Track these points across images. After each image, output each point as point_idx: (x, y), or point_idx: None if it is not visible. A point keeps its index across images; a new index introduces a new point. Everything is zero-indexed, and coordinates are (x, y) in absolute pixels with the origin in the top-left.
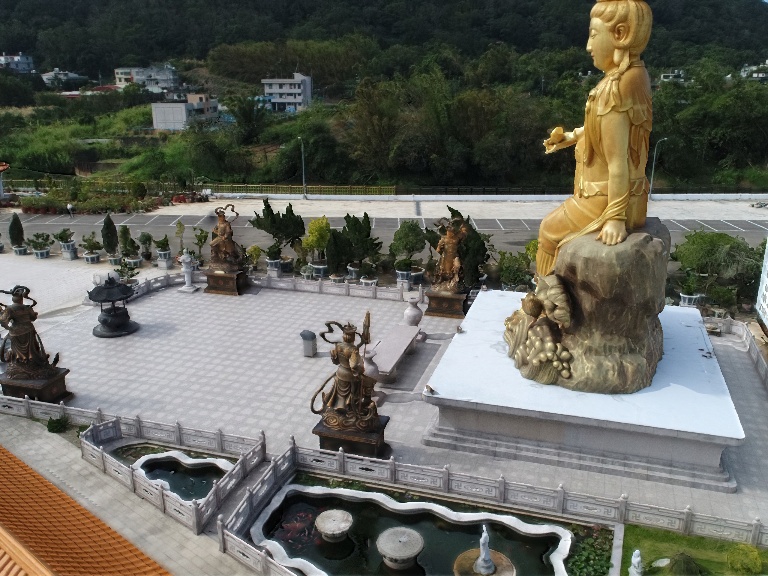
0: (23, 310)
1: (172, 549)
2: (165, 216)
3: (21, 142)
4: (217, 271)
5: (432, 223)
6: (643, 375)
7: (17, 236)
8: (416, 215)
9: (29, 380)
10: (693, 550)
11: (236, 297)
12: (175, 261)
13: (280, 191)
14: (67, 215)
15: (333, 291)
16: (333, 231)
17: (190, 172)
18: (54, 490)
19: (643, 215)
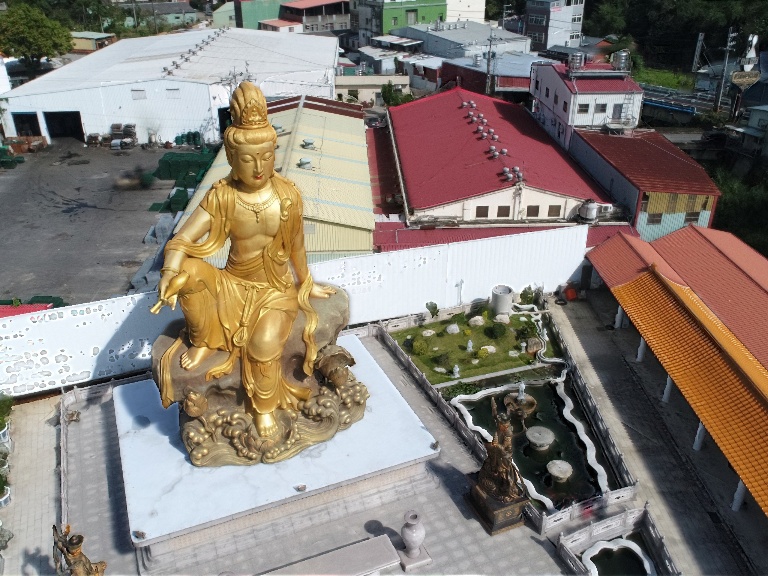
0: None
1: (666, 519)
2: None
3: None
4: None
5: None
6: None
7: None
8: None
9: None
10: (419, 367)
11: None
12: None
13: None
14: None
15: None
16: None
17: None
18: (754, 490)
19: None
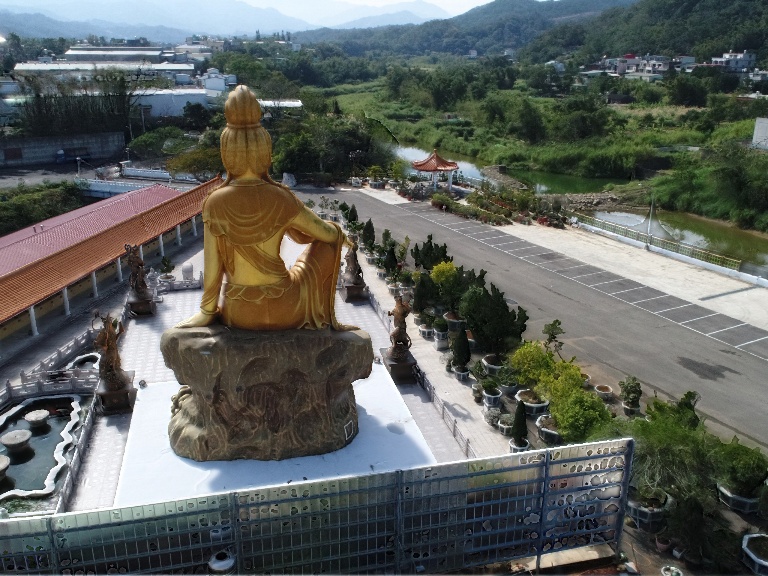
0: (134, 258)
1: None
2: (497, 232)
3: (601, 143)
4: (342, 279)
5: (683, 311)
6: (192, 448)
7: (353, 220)
8: (697, 298)
9: (132, 297)
10: None
11: (342, 303)
12: (397, 267)
13: (629, 235)
14: (448, 213)
15: (386, 324)
16: (426, 276)
17: (564, 198)
18: None
19: (245, 319)
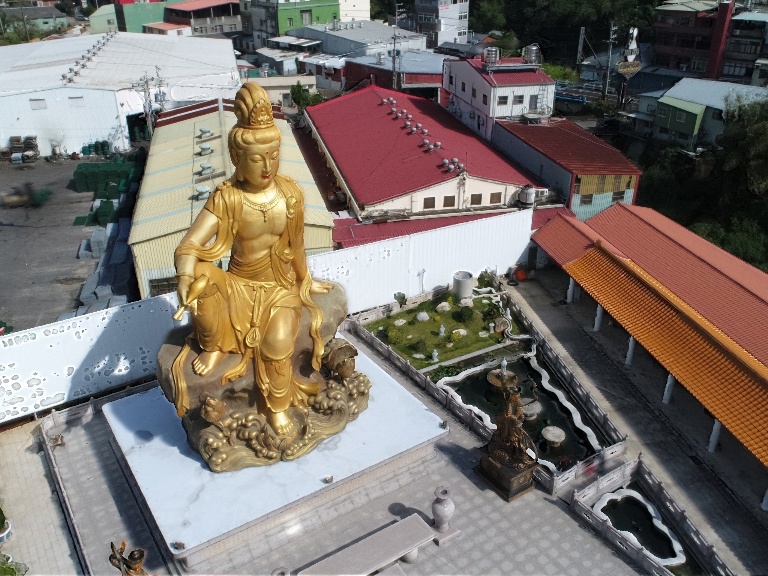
0: None
1: (656, 467)
2: None
3: None
4: None
5: None
6: None
7: None
8: None
9: None
10: None
11: None
12: None
13: None
14: None
15: None
16: None
17: None
18: (734, 430)
19: None
